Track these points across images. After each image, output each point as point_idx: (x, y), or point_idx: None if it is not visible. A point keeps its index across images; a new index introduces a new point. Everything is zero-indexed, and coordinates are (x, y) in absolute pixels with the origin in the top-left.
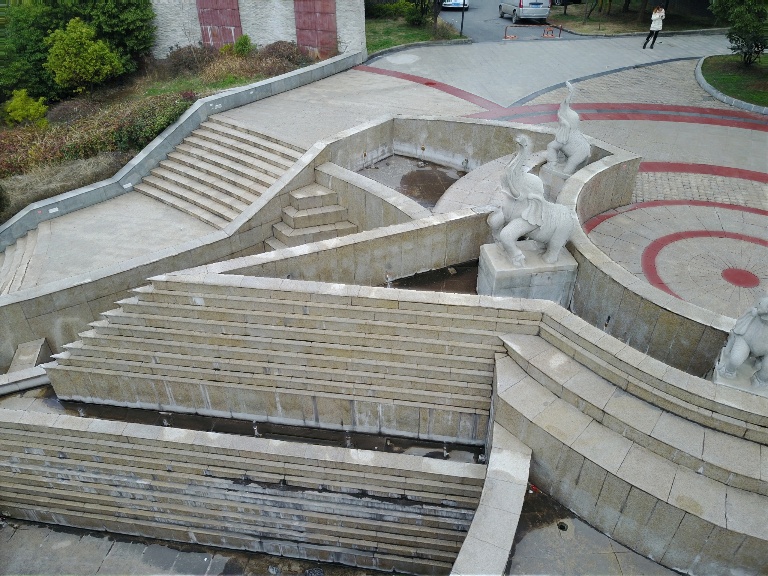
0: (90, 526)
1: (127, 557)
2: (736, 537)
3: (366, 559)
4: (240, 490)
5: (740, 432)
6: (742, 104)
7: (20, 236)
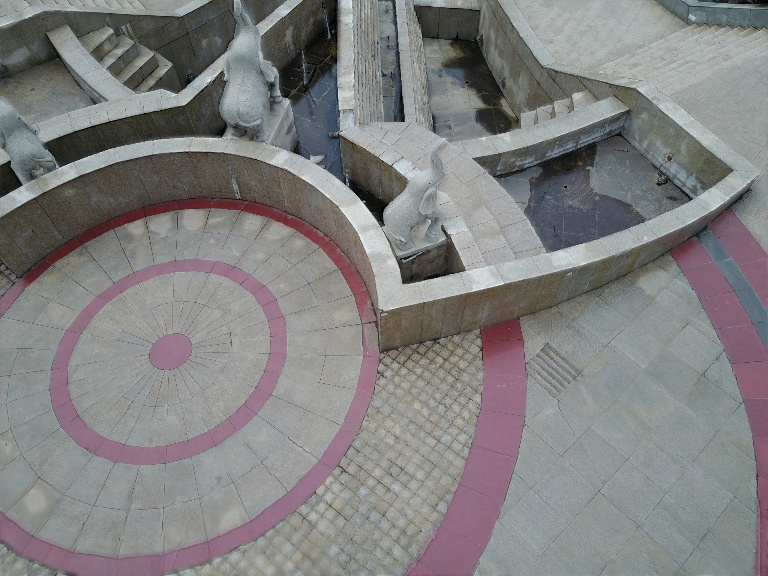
0: None
1: None
2: None
3: None
4: None
5: None
6: None
7: None
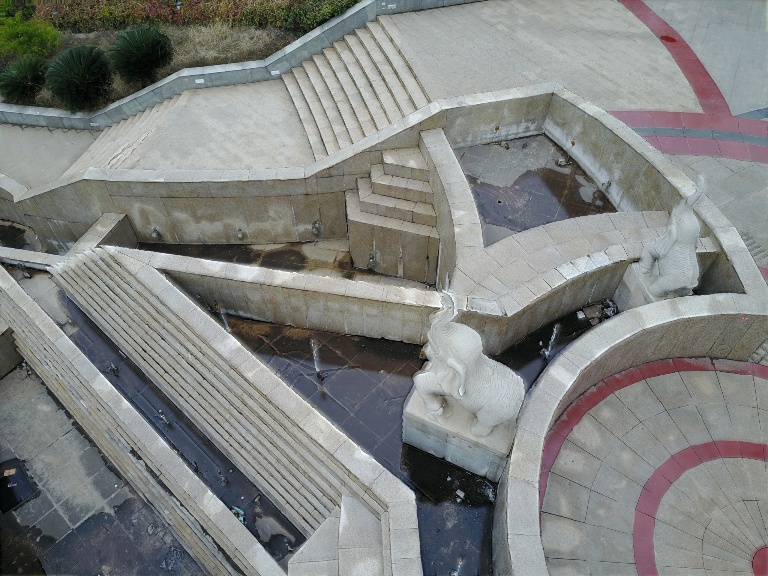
0: None
1: (73, 447)
2: None
3: None
4: None
5: None
6: None
7: (169, 97)
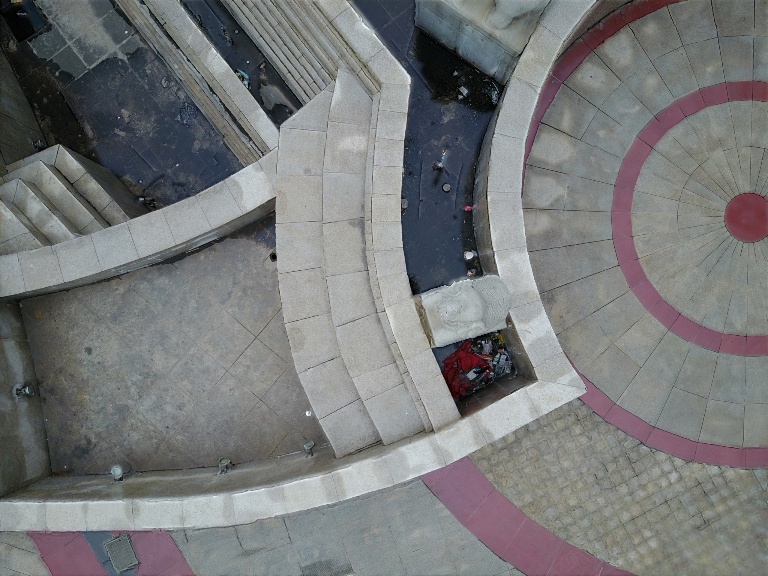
0: None
1: None
2: None
3: None
4: None
5: None
6: None
7: None
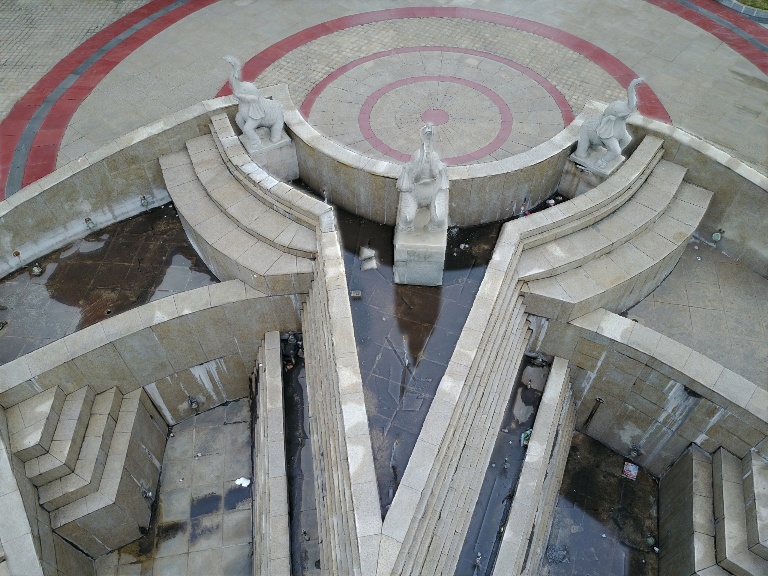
0: None
1: None
2: None
3: None
4: None
5: None
6: None
7: None
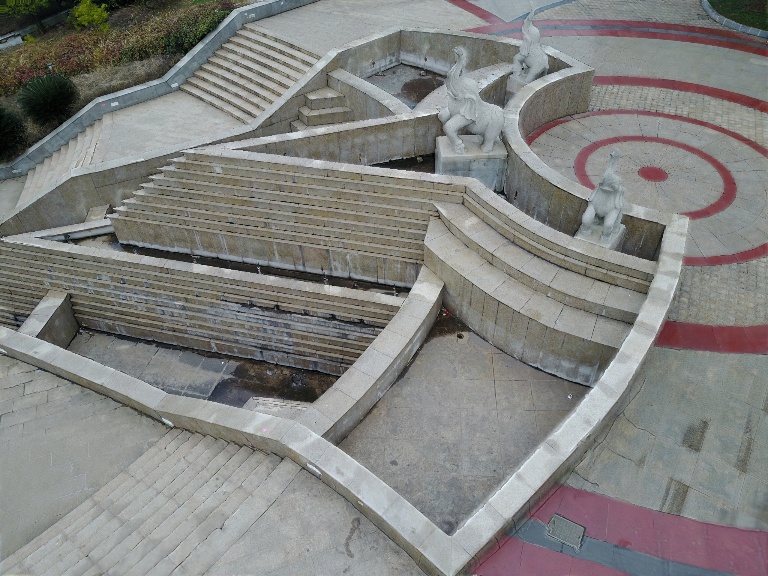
0: (143, 336)
1: (168, 358)
2: (560, 335)
3: (336, 368)
4: (247, 312)
5: (582, 271)
6: (731, 24)
7: (89, 125)
